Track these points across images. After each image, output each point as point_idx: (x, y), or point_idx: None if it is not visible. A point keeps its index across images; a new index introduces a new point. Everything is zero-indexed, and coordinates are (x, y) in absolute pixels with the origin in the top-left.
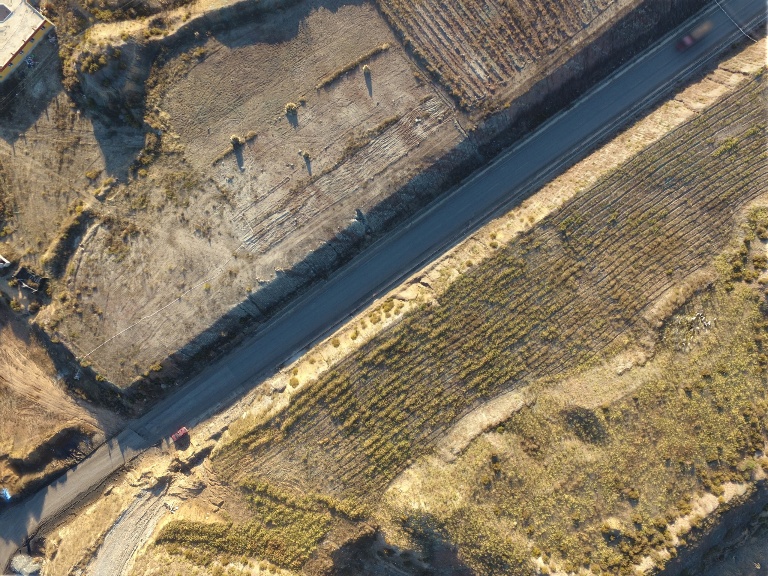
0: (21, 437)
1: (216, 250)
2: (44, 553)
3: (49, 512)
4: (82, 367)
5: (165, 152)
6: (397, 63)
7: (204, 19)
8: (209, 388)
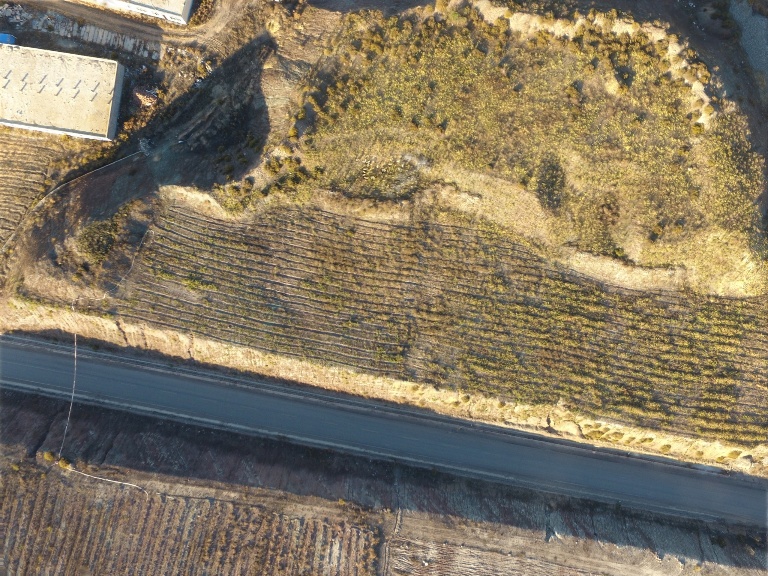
0: None
1: None
2: None
3: None
4: None
5: None
6: None
7: None
8: None
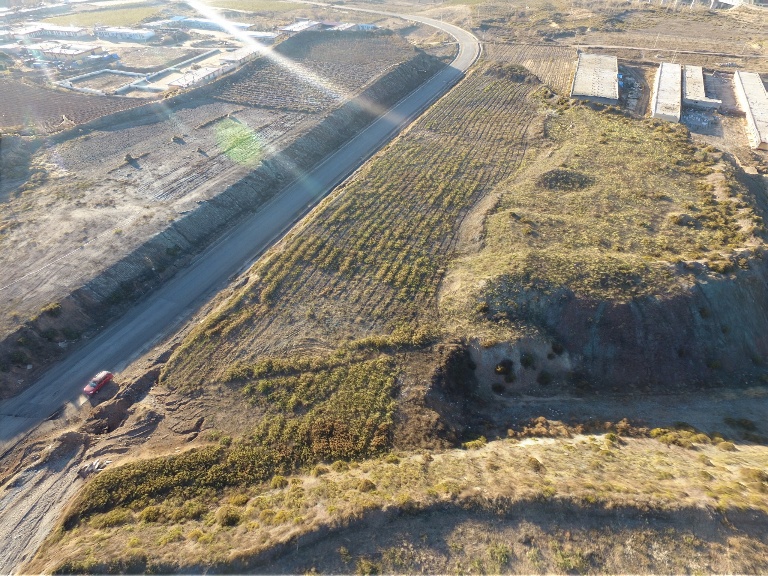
0: None
1: (123, 210)
2: None
3: None
4: None
5: (54, 178)
6: (252, 112)
7: (87, 125)
8: (139, 325)
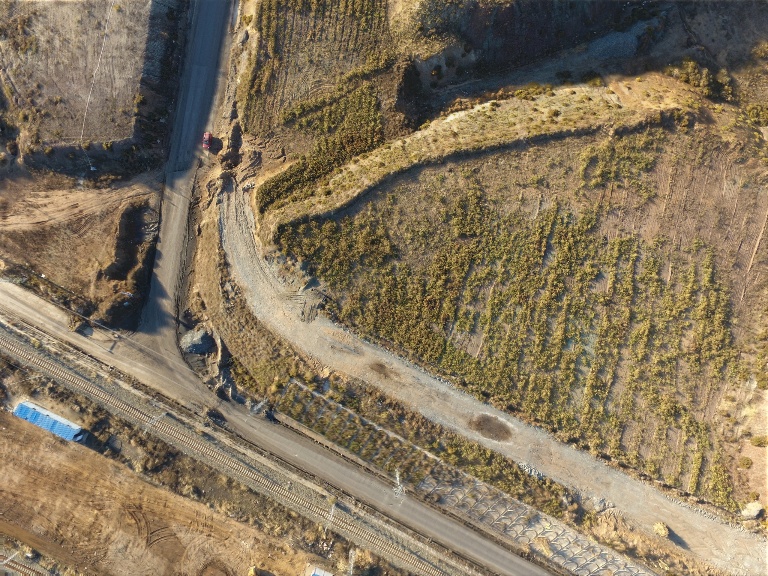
0: (97, 250)
1: None
2: (197, 318)
3: (172, 288)
4: (87, 152)
5: None
6: None
7: None
8: (196, 92)
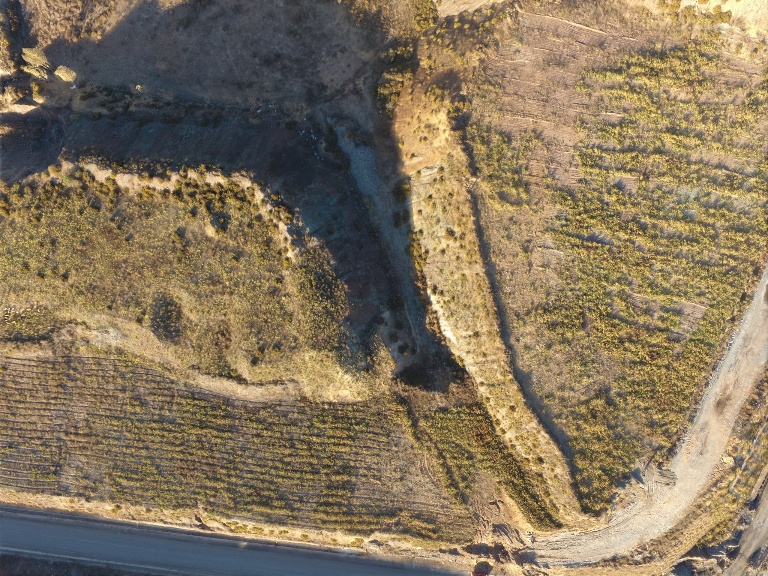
0: None
1: None
2: None
3: None
4: None
5: None
6: None
7: None
8: None
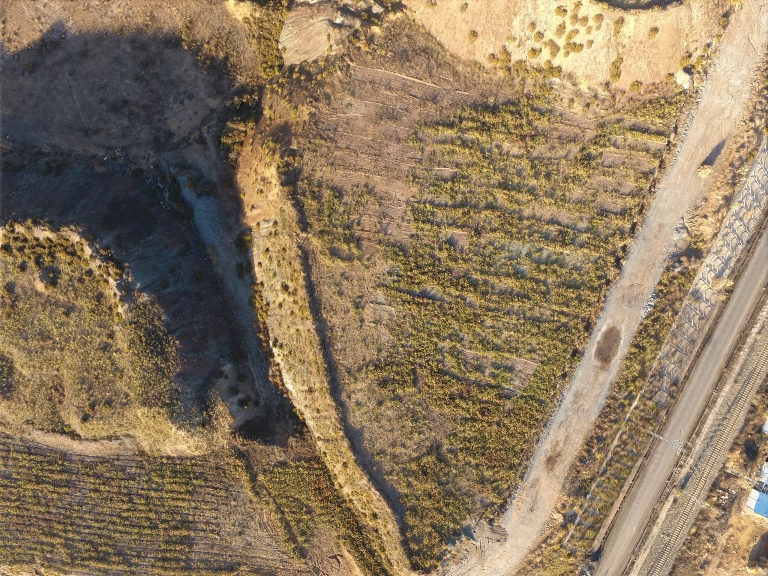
0: None
1: None
2: None
3: None
4: None
5: None
6: None
7: None
8: None
